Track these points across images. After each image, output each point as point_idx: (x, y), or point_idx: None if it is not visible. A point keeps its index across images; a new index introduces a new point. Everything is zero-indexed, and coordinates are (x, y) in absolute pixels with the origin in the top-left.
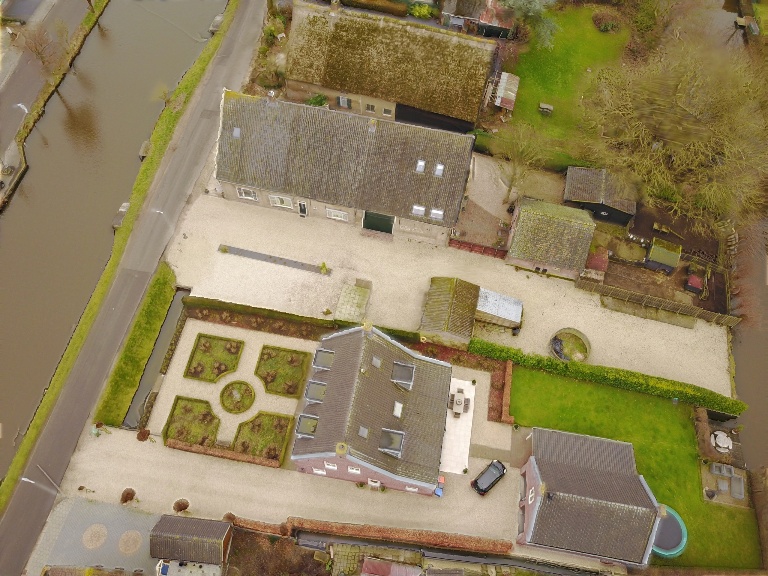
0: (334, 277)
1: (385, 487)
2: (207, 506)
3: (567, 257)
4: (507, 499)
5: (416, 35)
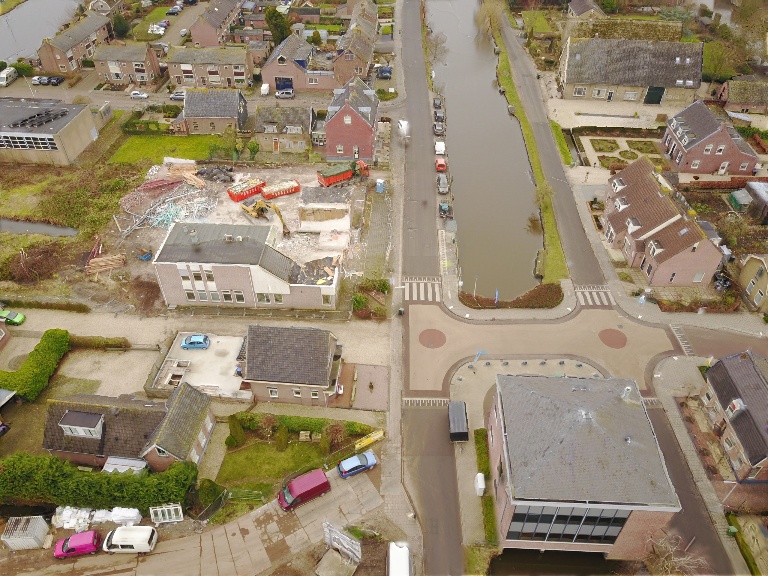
0: (642, 119)
1: None
2: None
3: (759, 99)
4: None
5: (638, 24)
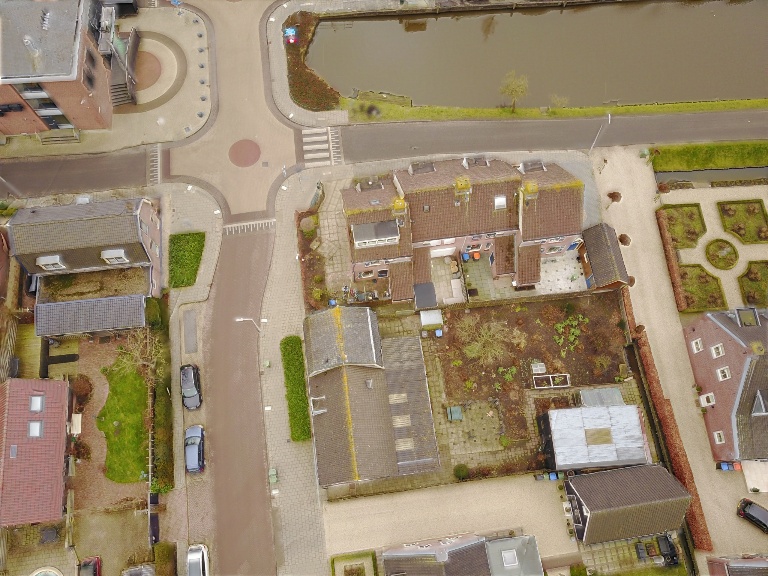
0: None
1: (705, 412)
2: (624, 263)
3: None
4: (745, 540)
5: None
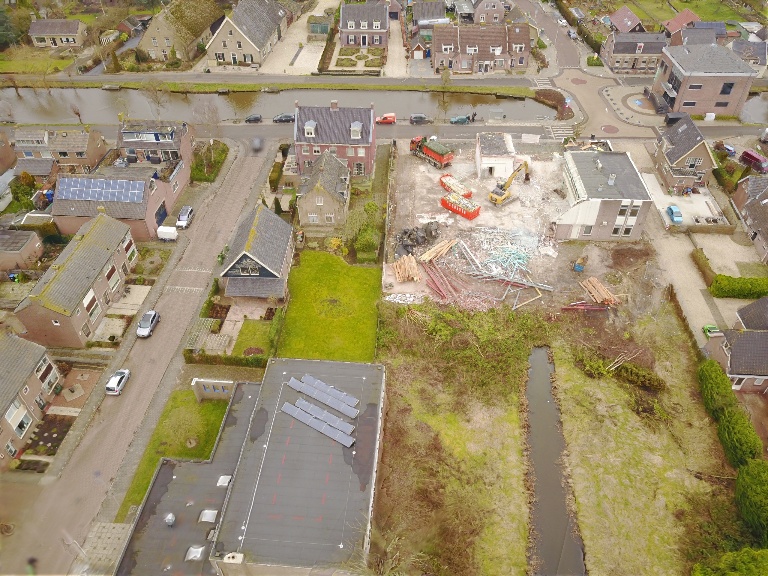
0: None
1: None
2: None
3: (296, 5)
4: None
5: None
